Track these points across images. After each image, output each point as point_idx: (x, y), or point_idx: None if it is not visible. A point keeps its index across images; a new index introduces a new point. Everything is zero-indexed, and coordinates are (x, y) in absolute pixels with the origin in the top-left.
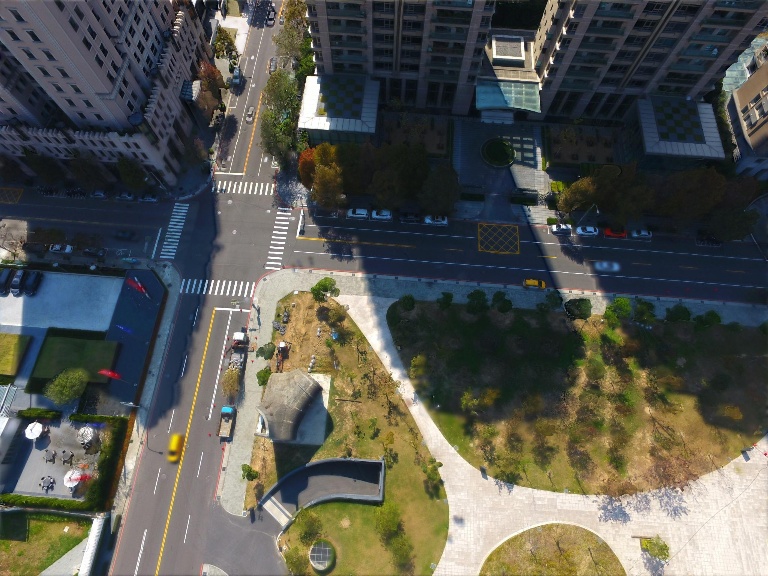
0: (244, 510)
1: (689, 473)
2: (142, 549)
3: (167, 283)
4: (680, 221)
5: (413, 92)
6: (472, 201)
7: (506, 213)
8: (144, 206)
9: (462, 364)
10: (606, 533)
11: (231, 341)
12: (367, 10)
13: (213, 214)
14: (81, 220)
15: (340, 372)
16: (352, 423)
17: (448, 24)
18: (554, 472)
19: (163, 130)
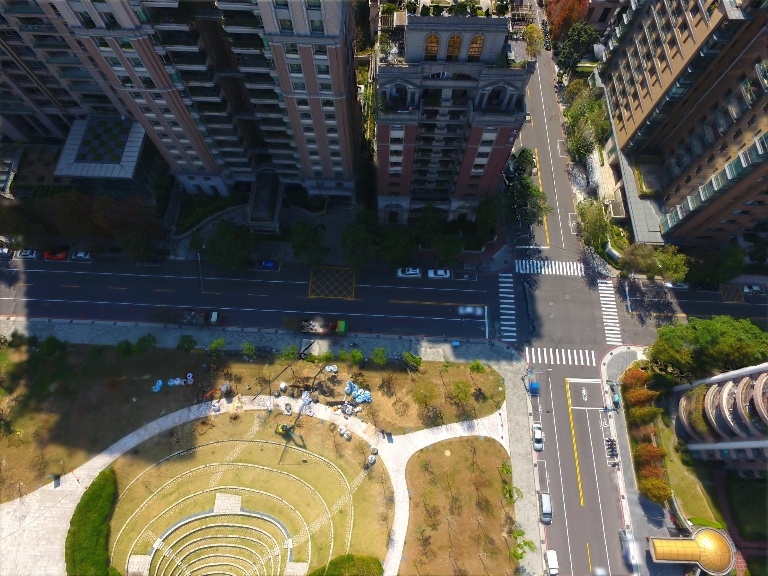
0: None
1: None
2: None
3: None
4: None
5: None
6: None
7: None
8: None
9: None
10: None
11: None
12: None
13: None
14: None
15: None
16: None
17: None
18: None
19: None
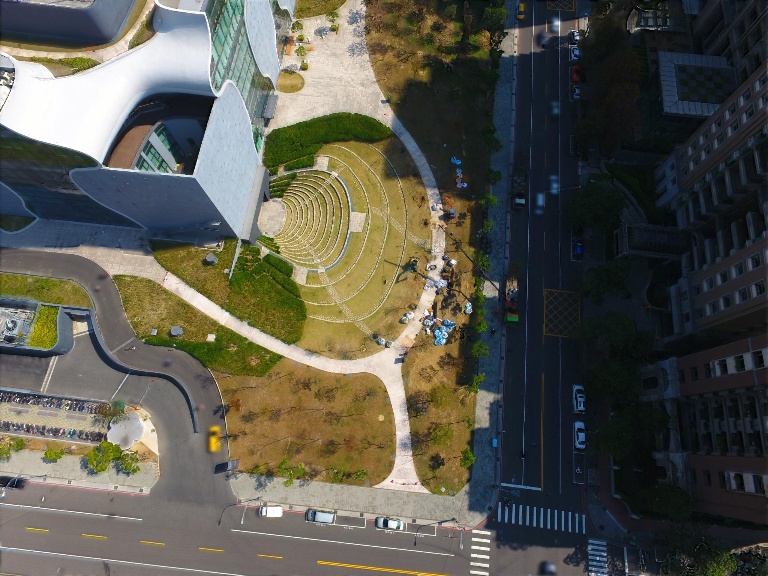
0: None
1: None
2: None
3: None
4: None
5: None
6: None
7: (586, 5)
8: None
9: None
10: (342, 11)
11: None
12: None
13: None
14: None
15: None
16: None
17: None
18: None
19: None
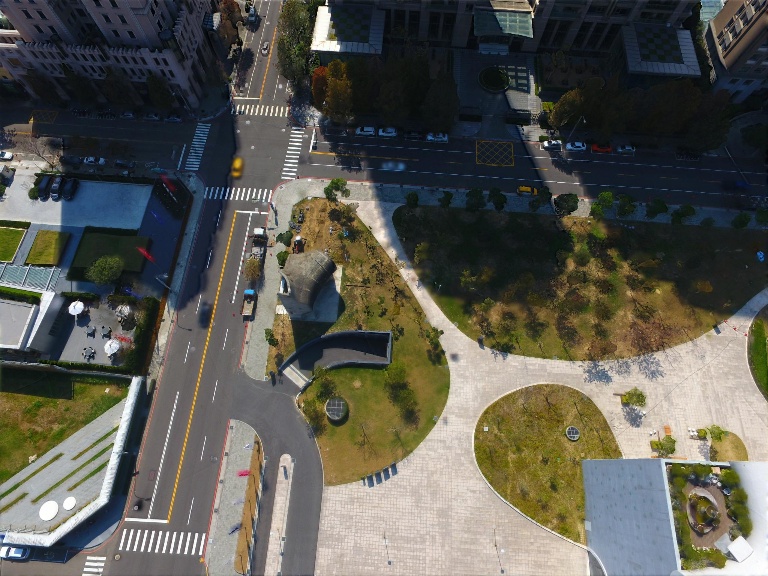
0: (266, 376)
1: (664, 333)
2: (175, 407)
3: (192, 190)
4: (661, 139)
5: (416, 25)
6: (470, 121)
7: (502, 132)
8: (169, 126)
9: (461, 257)
10: (590, 391)
11: (251, 238)
12: None
13: (233, 132)
14: (112, 137)
15: (351, 263)
16: (362, 304)
17: None
18: (544, 343)
19: (188, 52)
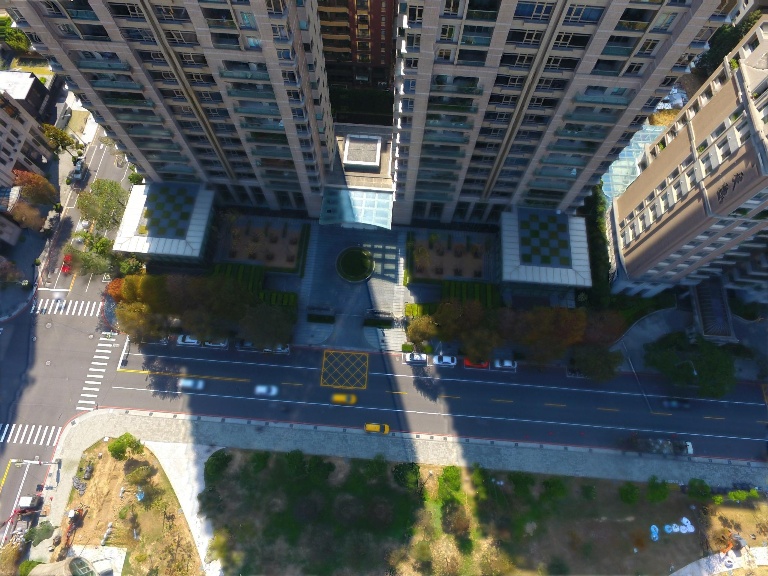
0: None
1: None
2: None
3: None
4: None
5: (263, 195)
6: (321, 323)
7: (357, 338)
8: None
9: (280, 533)
10: None
11: None
12: (172, 129)
13: (28, 340)
14: None
15: (140, 543)
16: None
17: (266, 144)
18: None
19: None
